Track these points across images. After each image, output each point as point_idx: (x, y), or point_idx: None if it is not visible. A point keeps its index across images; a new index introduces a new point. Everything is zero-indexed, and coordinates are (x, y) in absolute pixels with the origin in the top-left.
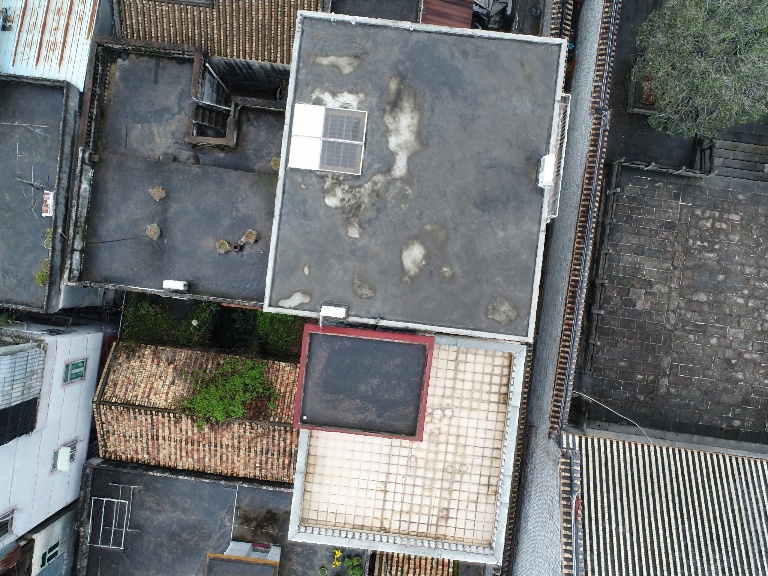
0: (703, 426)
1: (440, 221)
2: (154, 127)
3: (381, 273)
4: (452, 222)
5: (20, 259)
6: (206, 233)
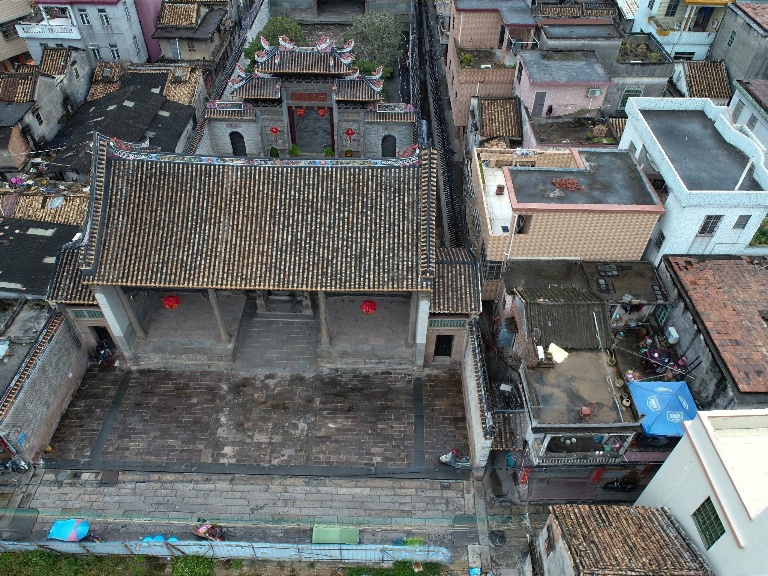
0: (345, 25)
1: None
2: None
3: None
4: None
5: None
6: None
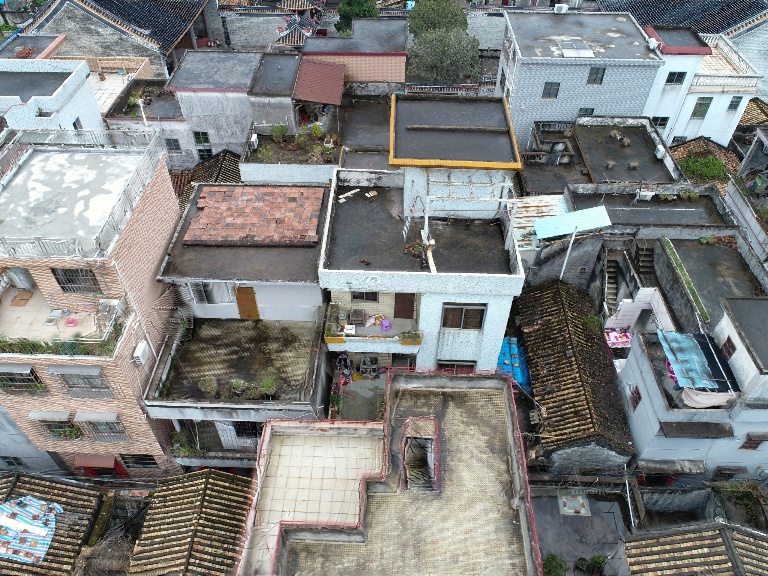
0: None
1: (594, 30)
2: (567, 180)
3: (626, 40)
4: (592, 28)
5: (688, 212)
6: (621, 151)
